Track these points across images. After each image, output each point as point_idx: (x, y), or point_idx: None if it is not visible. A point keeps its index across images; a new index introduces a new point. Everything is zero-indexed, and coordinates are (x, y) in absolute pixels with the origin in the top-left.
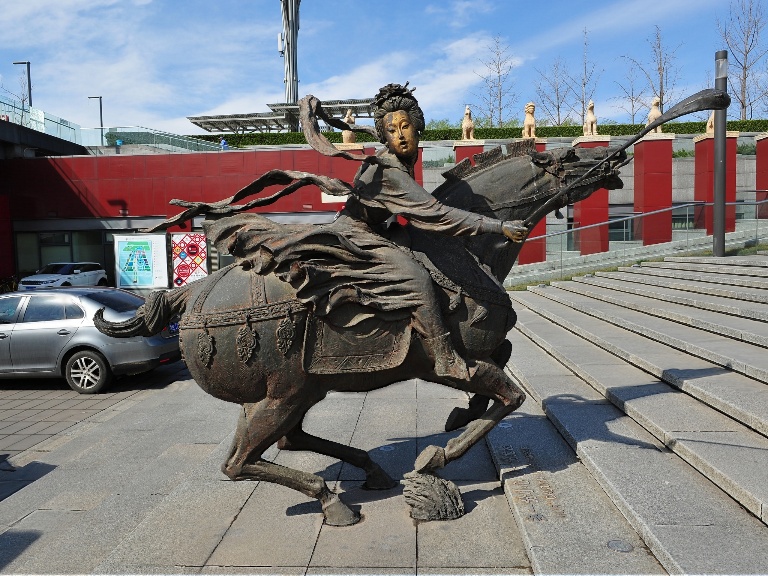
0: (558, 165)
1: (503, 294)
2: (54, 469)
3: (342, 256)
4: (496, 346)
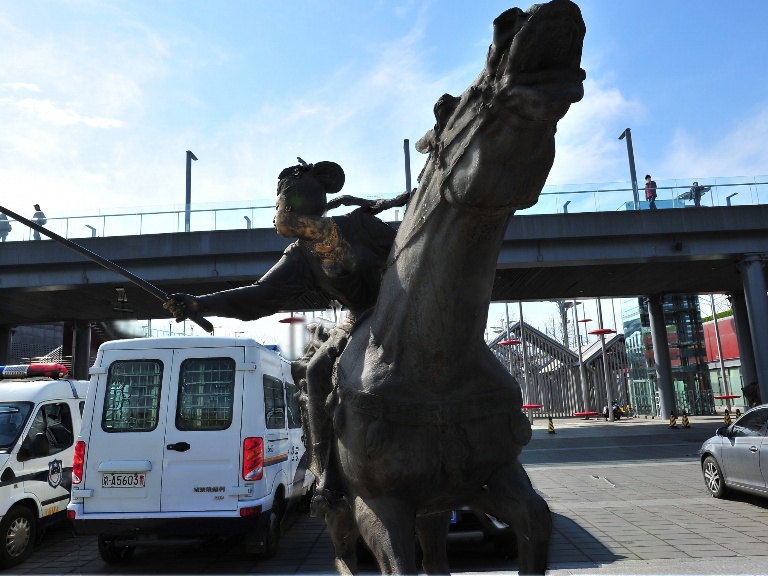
0: (432, 143)
1: (356, 392)
2: (564, 569)
3: (316, 349)
4: (364, 478)
